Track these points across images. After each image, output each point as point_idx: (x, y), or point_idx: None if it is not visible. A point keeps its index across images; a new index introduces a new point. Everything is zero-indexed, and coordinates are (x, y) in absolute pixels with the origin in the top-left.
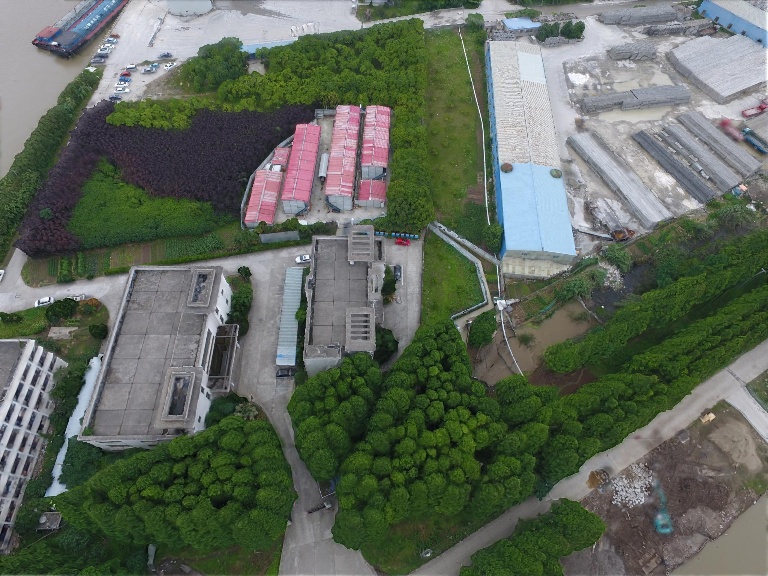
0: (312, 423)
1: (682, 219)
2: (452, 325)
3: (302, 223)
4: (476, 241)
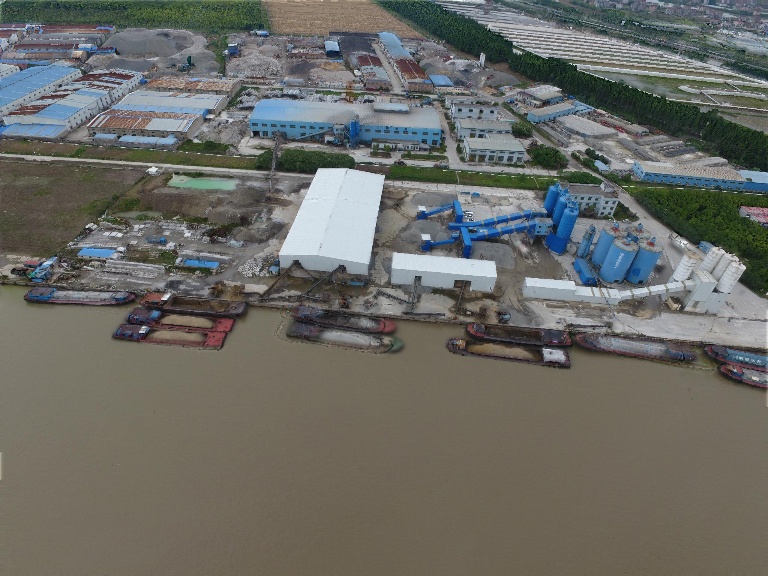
0: None
1: None
2: None
3: None
4: None
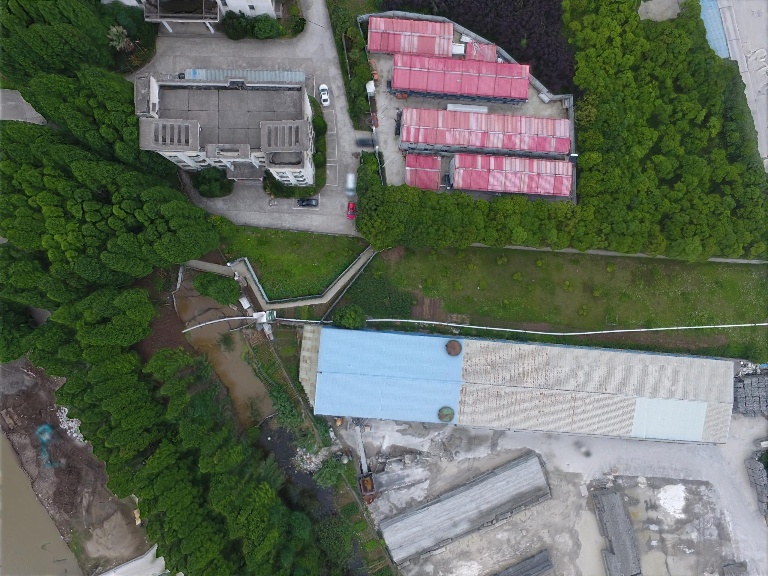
0: (46, 79)
1: (396, 575)
2: (181, 238)
3: (370, 86)
4: (353, 300)
